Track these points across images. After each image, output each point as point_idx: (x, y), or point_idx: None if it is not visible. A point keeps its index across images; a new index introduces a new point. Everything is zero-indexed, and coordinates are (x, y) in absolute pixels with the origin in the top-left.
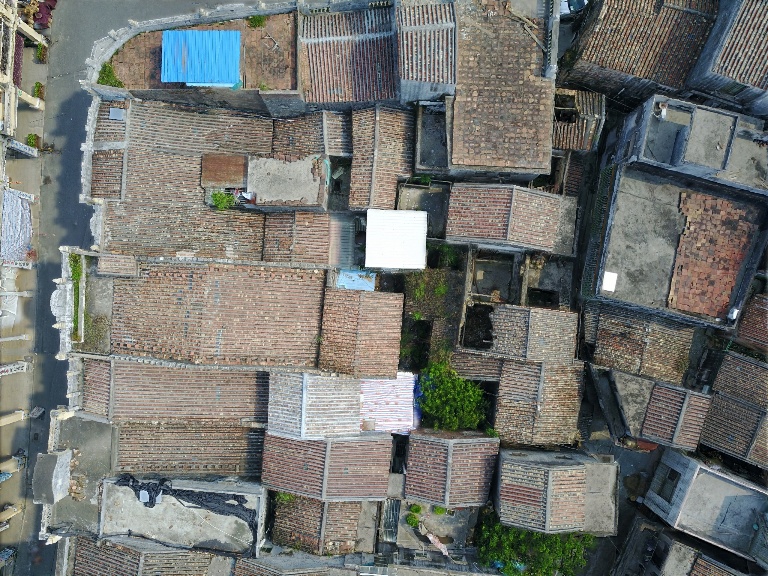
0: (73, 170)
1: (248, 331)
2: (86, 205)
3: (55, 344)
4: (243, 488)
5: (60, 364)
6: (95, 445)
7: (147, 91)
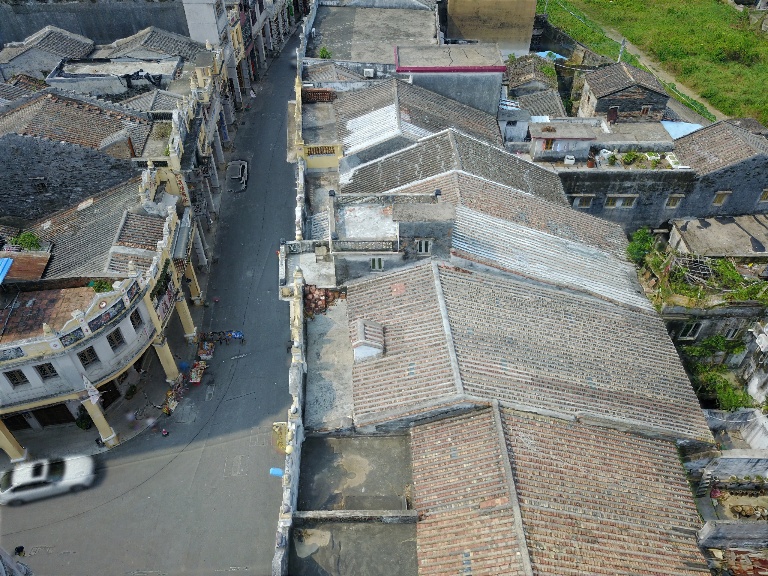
0: (273, 335)
1: (4, 125)
2: (257, 307)
3: (288, 212)
4: (66, 88)
5: (283, 202)
6: (181, 91)
7: (59, 281)
